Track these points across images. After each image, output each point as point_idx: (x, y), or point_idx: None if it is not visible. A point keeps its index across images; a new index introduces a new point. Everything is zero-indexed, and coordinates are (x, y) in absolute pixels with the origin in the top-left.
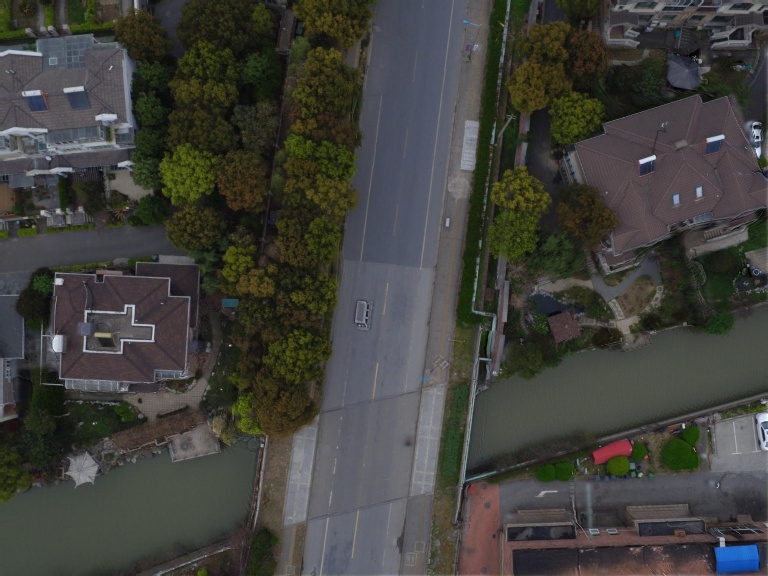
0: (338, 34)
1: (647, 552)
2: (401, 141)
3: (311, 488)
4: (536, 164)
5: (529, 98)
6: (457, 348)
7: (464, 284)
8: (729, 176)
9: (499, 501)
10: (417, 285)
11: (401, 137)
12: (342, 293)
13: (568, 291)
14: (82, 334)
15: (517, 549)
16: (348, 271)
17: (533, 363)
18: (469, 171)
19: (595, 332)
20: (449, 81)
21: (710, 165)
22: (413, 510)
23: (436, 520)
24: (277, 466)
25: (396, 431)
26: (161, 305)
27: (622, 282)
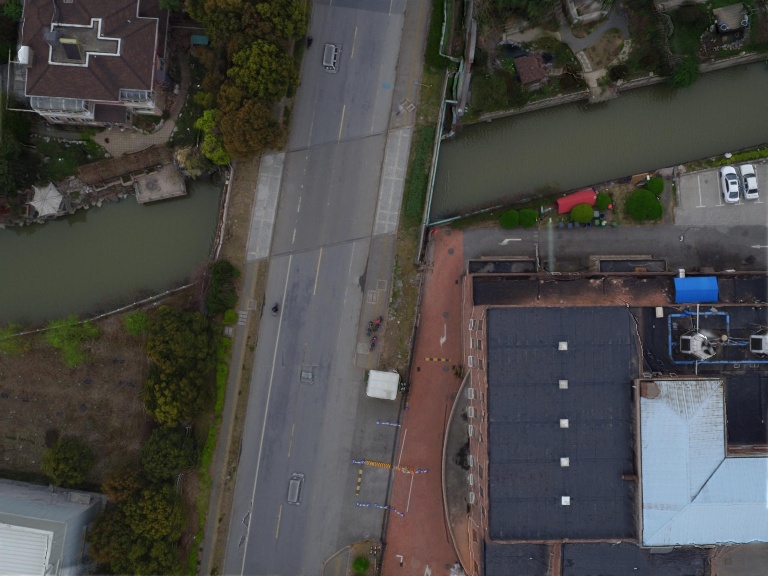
0: None
1: (607, 285)
2: None
3: (275, 225)
4: None
5: None
6: (424, 93)
7: (432, 29)
8: None
9: (463, 248)
10: (386, 30)
11: None
12: None
13: (536, 42)
14: (47, 40)
15: (477, 275)
16: (317, 13)
17: (497, 91)
18: None
19: (561, 77)
20: None
21: None
22: (376, 249)
23: (399, 260)
24: (241, 202)
25: (361, 172)
26: (128, 23)
27: (590, 34)
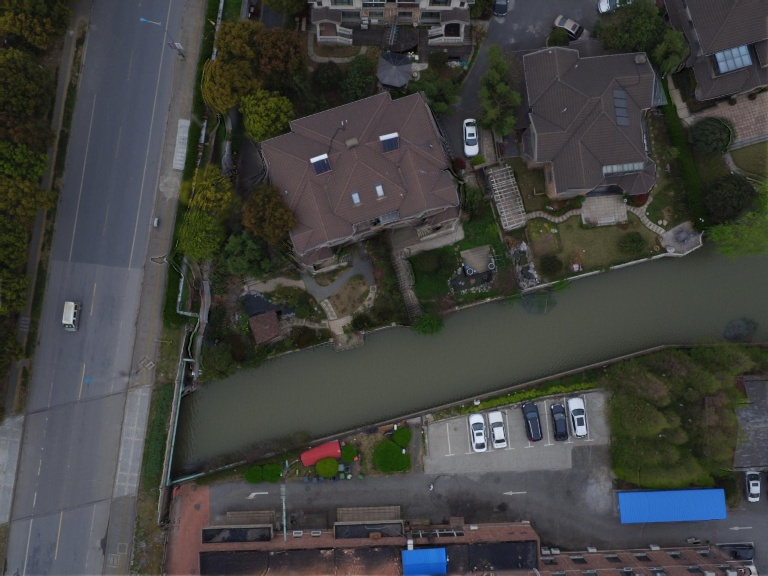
0: (22, 33)
1: (338, 555)
2: (114, 140)
3: (15, 489)
4: (250, 163)
5: (216, 96)
6: (164, 349)
7: (171, 284)
8: (410, 174)
9: (209, 503)
10: (125, 285)
11: (114, 136)
12: (47, 294)
13: (279, 291)
14: None
15: (203, 551)
16: (55, 272)
17: (220, 364)
18: (180, 170)
19: (300, 333)
20: (164, 80)
21: (392, 163)
22: (116, 511)
23: (140, 522)
24: None
25: (101, 432)
26: None
27: (334, 282)
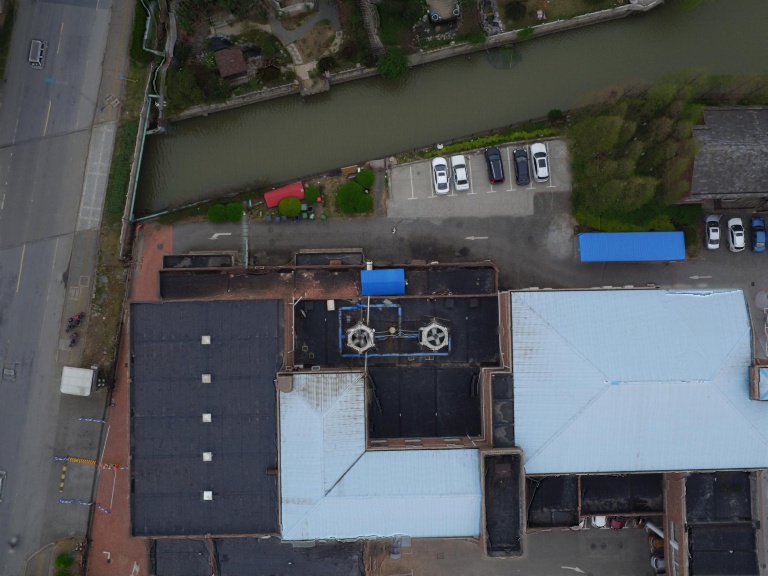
0: None
1: (298, 278)
2: None
3: None
4: None
5: None
6: (130, 87)
7: (137, 23)
8: None
9: (172, 243)
10: (92, 25)
11: None
12: (14, 30)
13: (246, 34)
14: None
15: (164, 270)
16: (22, 10)
17: (183, 85)
18: None
19: None
20: None
21: None
22: (79, 245)
23: (103, 256)
24: None
25: (65, 168)
26: None
27: (300, 26)
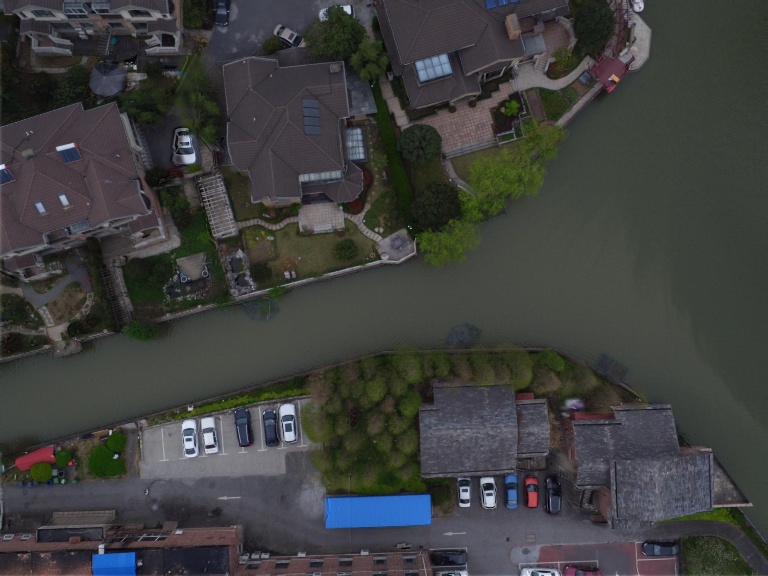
0: None
1: (36, 558)
2: None
3: None
4: None
5: None
6: None
7: None
8: (94, 184)
9: None
10: None
11: None
12: None
13: None
14: None
15: None
16: None
17: None
18: None
19: None
20: None
21: (78, 173)
22: None
23: None
24: None
25: None
26: None
27: (52, 289)
